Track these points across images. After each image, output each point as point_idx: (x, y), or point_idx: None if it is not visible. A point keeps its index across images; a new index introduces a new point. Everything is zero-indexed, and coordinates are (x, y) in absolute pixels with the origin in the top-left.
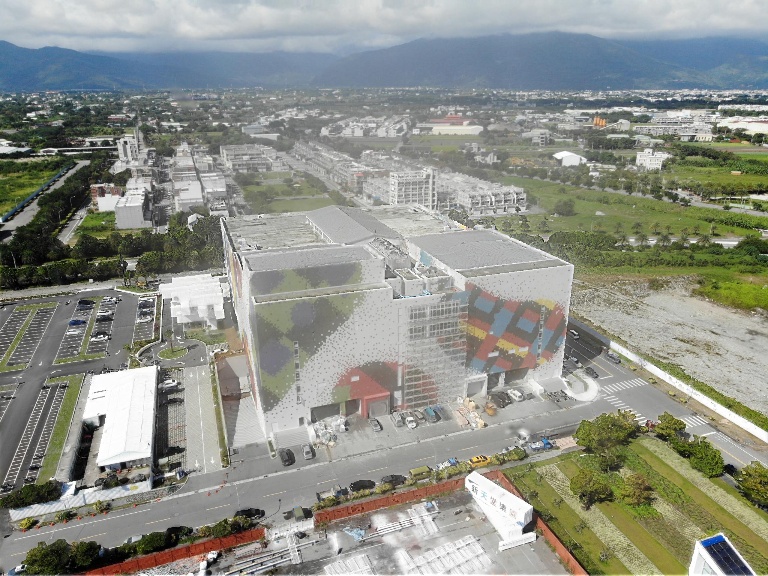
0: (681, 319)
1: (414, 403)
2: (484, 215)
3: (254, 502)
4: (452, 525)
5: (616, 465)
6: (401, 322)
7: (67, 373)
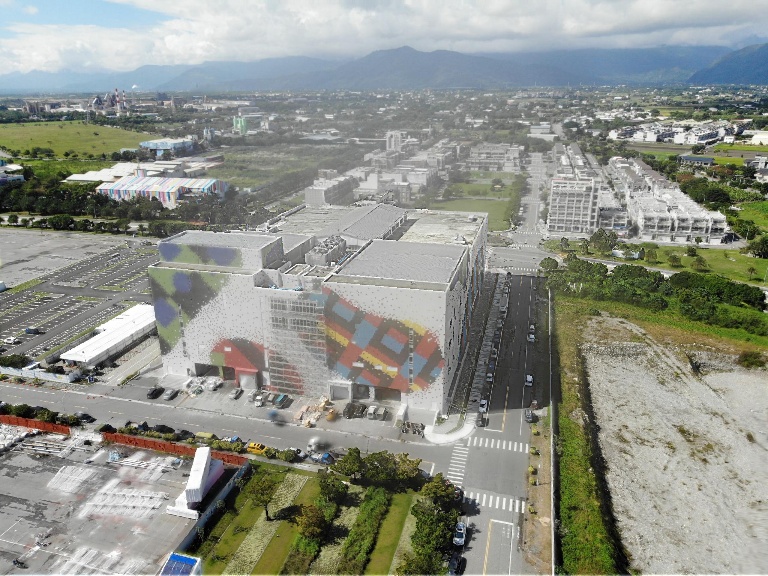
0: (727, 408)
1: (279, 387)
2: (655, 241)
3: (100, 412)
4: (169, 481)
5: (356, 502)
6: (263, 309)
7: (137, 300)
